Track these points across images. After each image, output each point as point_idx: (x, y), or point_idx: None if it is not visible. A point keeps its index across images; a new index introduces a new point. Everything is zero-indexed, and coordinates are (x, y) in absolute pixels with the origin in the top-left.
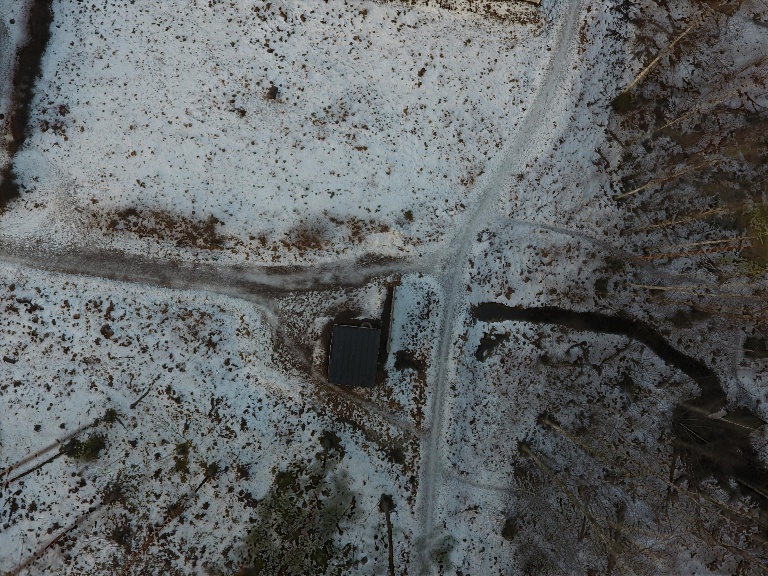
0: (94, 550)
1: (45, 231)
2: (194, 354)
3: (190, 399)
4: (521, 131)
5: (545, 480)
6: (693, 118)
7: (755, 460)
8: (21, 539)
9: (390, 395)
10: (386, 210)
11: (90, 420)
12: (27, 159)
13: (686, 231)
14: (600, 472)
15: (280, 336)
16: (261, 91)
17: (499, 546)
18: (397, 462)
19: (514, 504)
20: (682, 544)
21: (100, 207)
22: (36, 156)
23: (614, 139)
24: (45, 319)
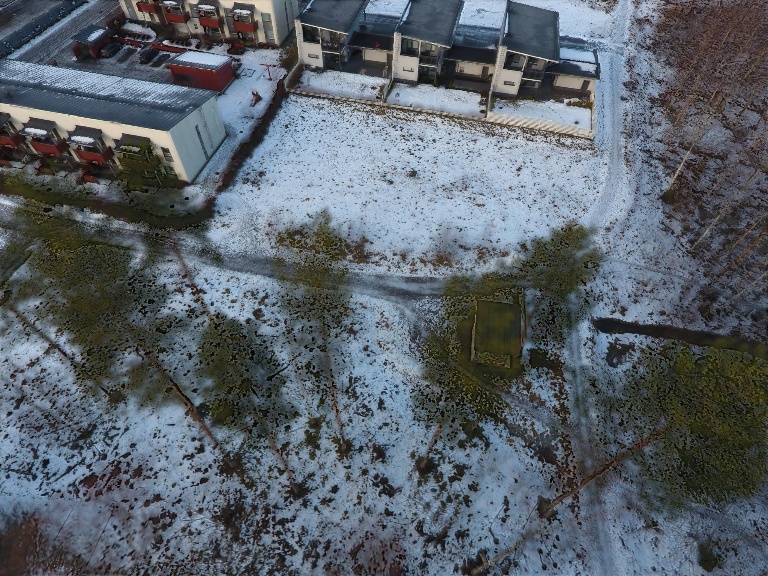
0: (194, 532)
1: (225, 242)
2: (335, 338)
3: (329, 375)
4: (600, 203)
5: (725, 495)
6: (726, 209)
7: None
8: (110, 511)
9: (529, 388)
10: (505, 242)
11: (224, 388)
12: (227, 197)
13: None
14: None
15: (417, 329)
16: (405, 173)
17: None
18: (548, 462)
19: (699, 523)
20: None
21: (274, 229)
22: (234, 196)
23: (671, 217)
24: (205, 301)
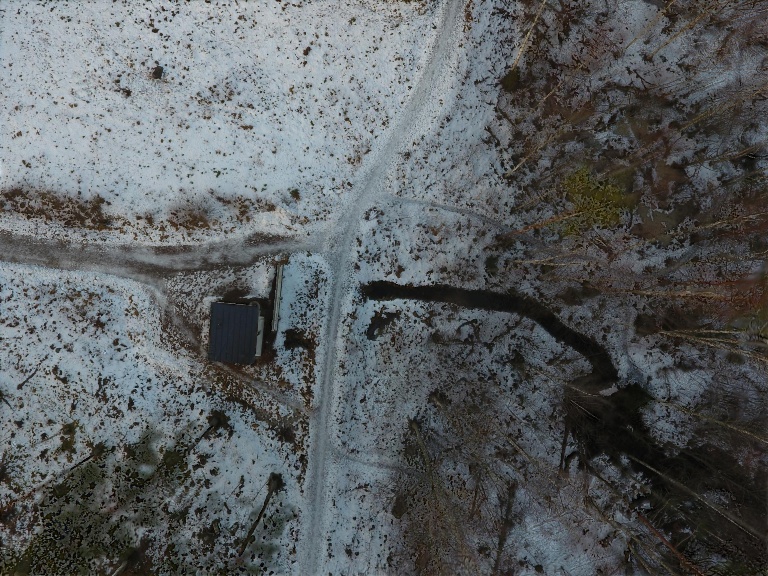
0: None
1: None
2: (82, 334)
3: (77, 379)
4: (407, 109)
5: (436, 458)
6: (583, 96)
7: (646, 436)
8: None
9: (279, 374)
10: (272, 189)
11: None
12: None
13: (576, 208)
14: (492, 450)
15: (168, 316)
16: (146, 71)
17: (389, 524)
18: (287, 441)
19: (404, 482)
20: (574, 521)
21: None
22: None
23: (504, 117)
24: None
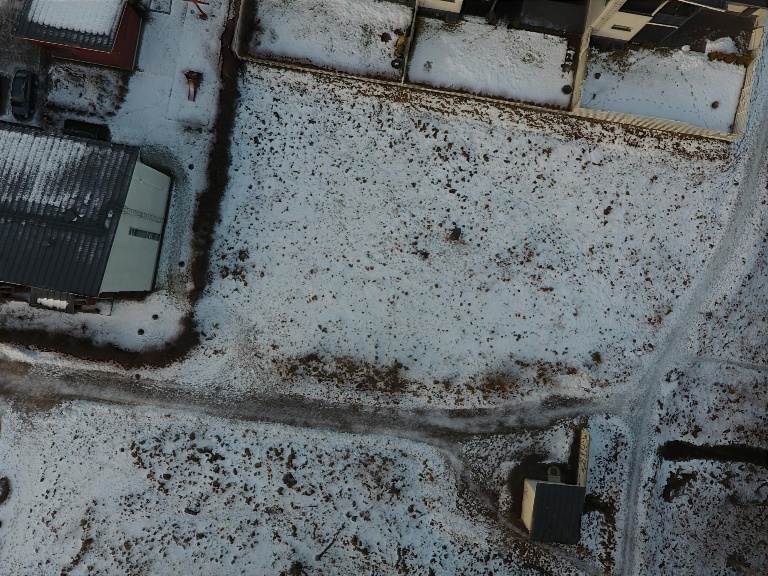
0: None
1: (224, 378)
2: (378, 501)
3: (376, 550)
4: (709, 268)
5: None
6: None
7: None
8: None
9: (578, 540)
10: (573, 352)
11: (275, 573)
12: (207, 306)
13: None
14: None
15: (465, 481)
16: (444, 232)
17: None
18: None
19: None
20: None
21: (280, 353)
22: (216, 303)
23: None
24: (226, 469)
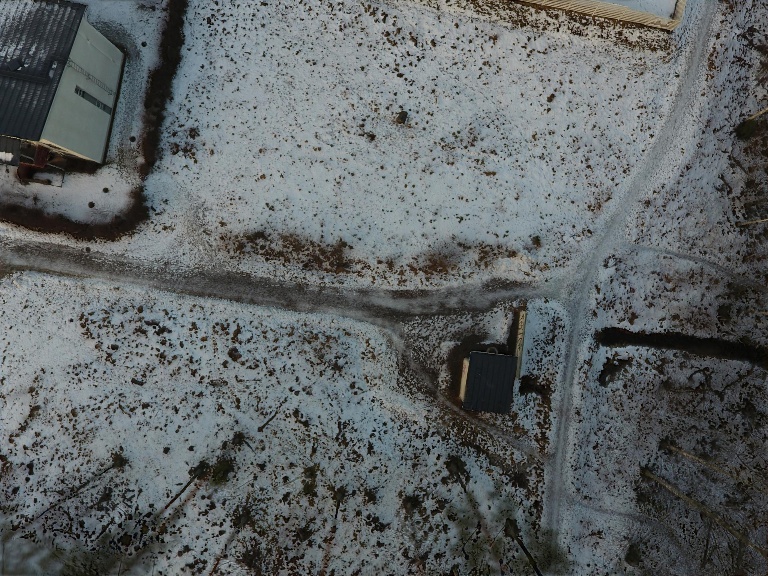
0: (224, 573)
1: (173, 253)
2: (320, 377)
3: (317, 422)
4: (649, 157)
5: (668, 506)
6: None
7: None
8: (152, 561)
9: (515, 420)
10: (514, 235)
11: (218, 443)
12: (157, 182)
13: None
14: (721, 498)
15: (406, 360)
16: (390, 115)
17: (622, 571)
18: (521, 487)
19: (637, 529)
20: None
21: (228, 230)
22: (166, 179)
23: (737, 165)
24: (173, 341)
